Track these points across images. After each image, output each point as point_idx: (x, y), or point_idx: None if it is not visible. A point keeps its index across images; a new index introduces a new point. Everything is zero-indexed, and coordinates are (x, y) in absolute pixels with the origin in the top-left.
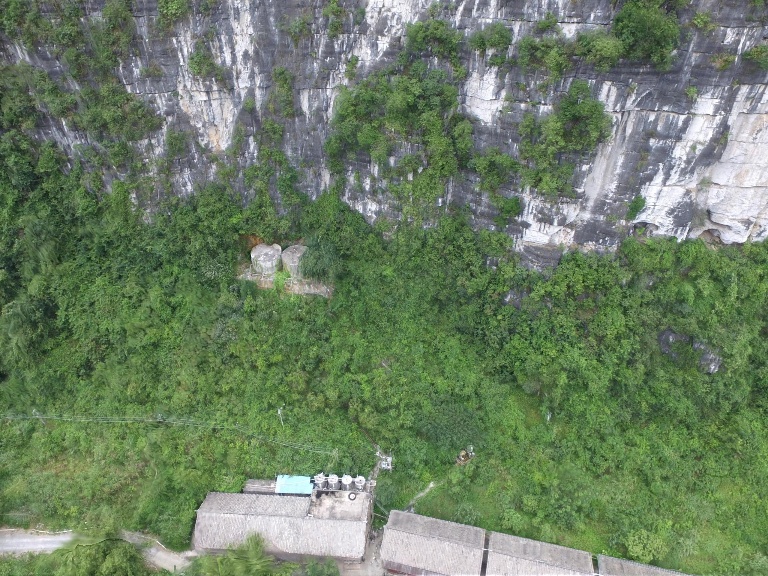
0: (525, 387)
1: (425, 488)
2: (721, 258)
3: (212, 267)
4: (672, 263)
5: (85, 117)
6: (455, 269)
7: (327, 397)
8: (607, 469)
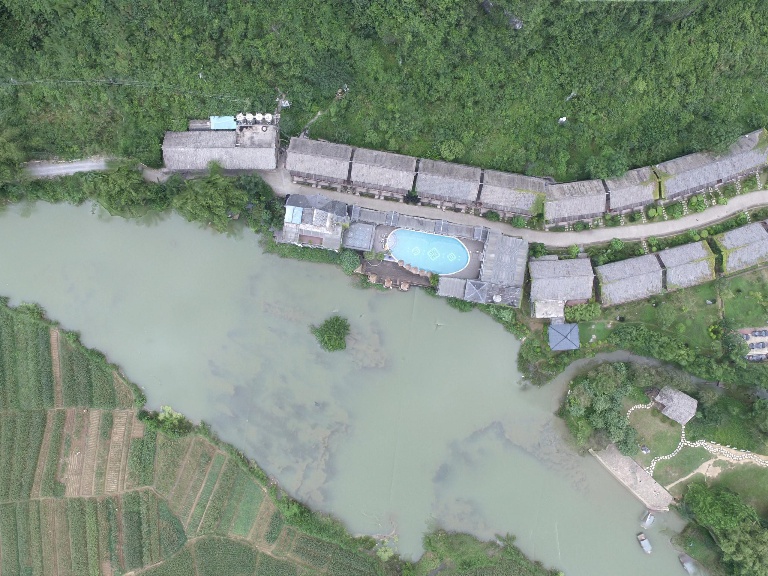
0: (384, 40)
1: (315, 116)
2: None
3: None
4: None
5: None
6: None
7: (234, 60)
8: (439, 98)
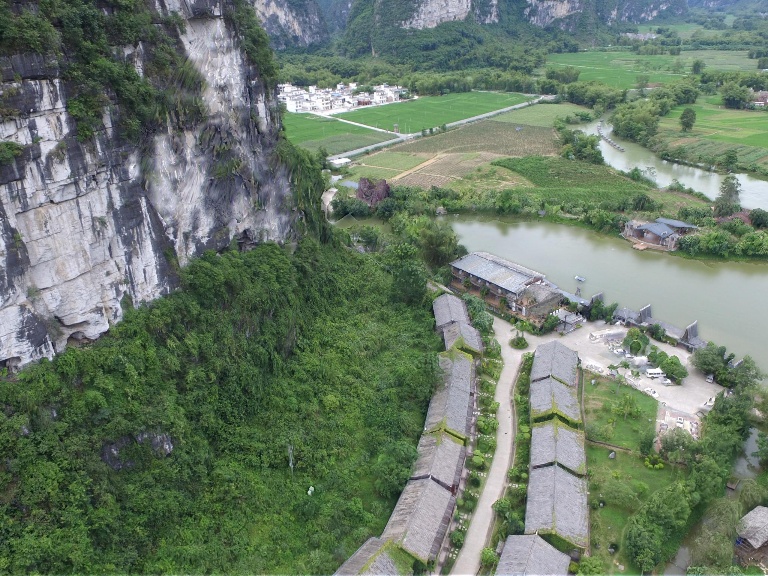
0: None
1: None
2: (100, 351)
3: None
4: (60, 381)
5: None
6: None
7: None
8: None
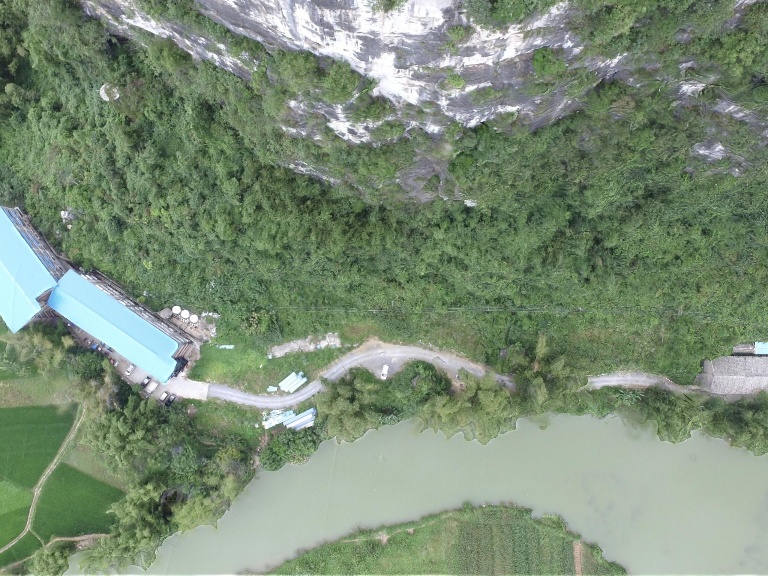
0: None
1: None
2: None
3: (760, 218)
4: None
5: (763, 160)
6: None
7: None
8: None
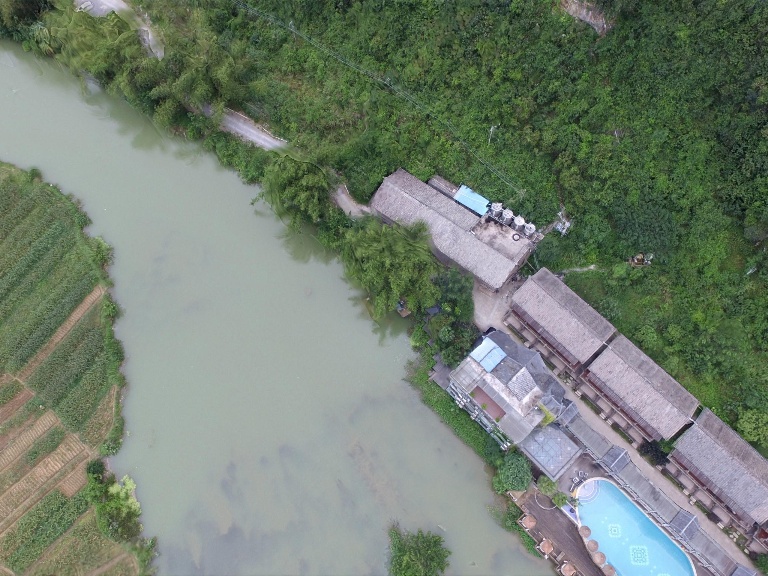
0: (748, 230)
1: (585, 266)
2: None
3: None
4: None
5: None
6: (762, 66)
7: (543, 137)
8: None
